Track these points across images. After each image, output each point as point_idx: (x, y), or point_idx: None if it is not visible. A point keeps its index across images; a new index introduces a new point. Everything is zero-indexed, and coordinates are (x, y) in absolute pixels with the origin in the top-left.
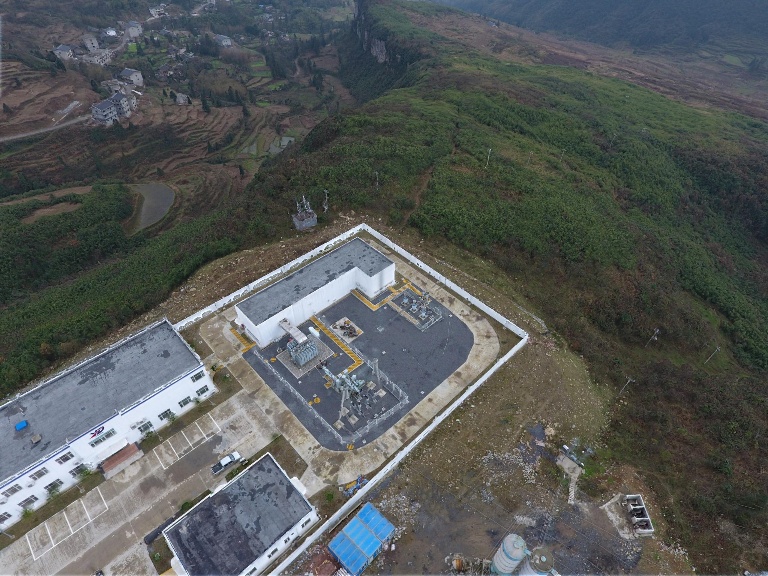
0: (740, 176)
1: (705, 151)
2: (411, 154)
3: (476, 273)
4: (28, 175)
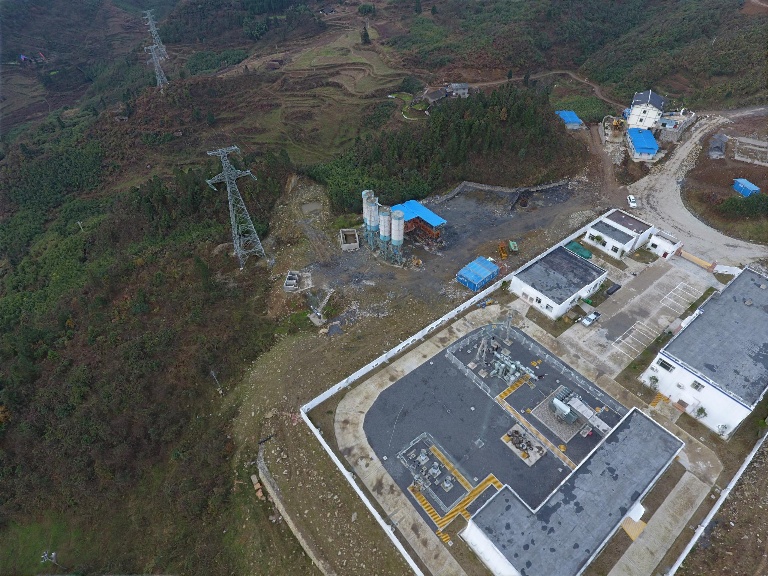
0: None
1: None
2: None
3: None
4: None
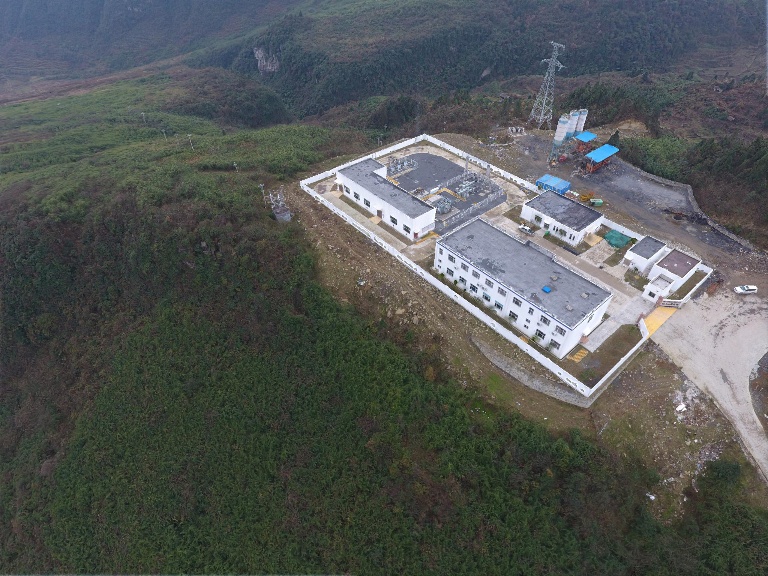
0: (207, 101)
1: (172, 100)
2: (176, 167)
3: (350, 159)
4: None
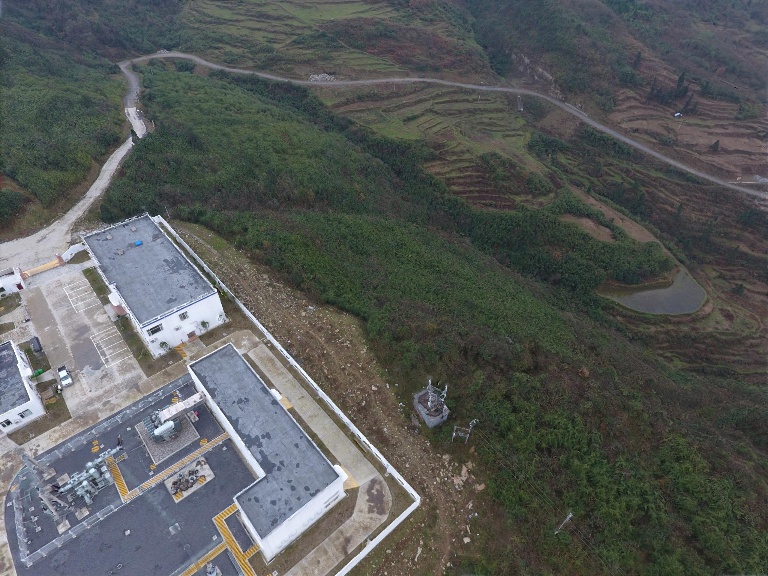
0: None
1: None
2: None
3: None
4: (648, 198)
